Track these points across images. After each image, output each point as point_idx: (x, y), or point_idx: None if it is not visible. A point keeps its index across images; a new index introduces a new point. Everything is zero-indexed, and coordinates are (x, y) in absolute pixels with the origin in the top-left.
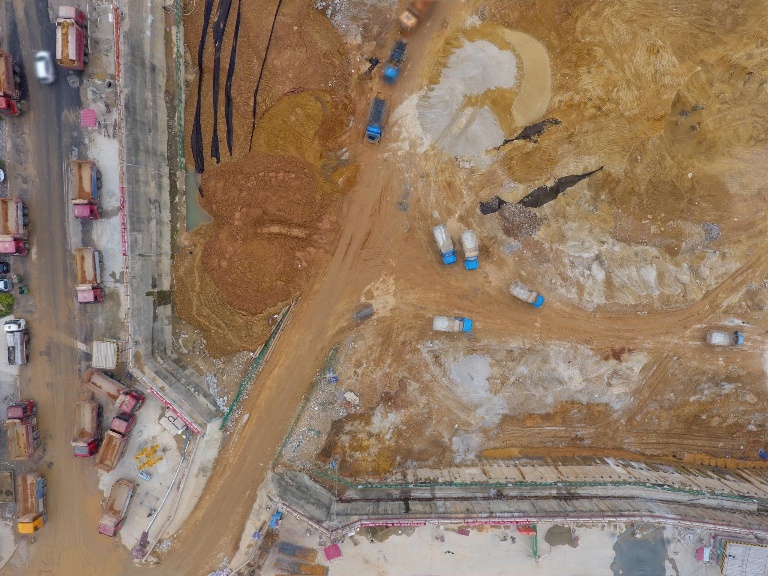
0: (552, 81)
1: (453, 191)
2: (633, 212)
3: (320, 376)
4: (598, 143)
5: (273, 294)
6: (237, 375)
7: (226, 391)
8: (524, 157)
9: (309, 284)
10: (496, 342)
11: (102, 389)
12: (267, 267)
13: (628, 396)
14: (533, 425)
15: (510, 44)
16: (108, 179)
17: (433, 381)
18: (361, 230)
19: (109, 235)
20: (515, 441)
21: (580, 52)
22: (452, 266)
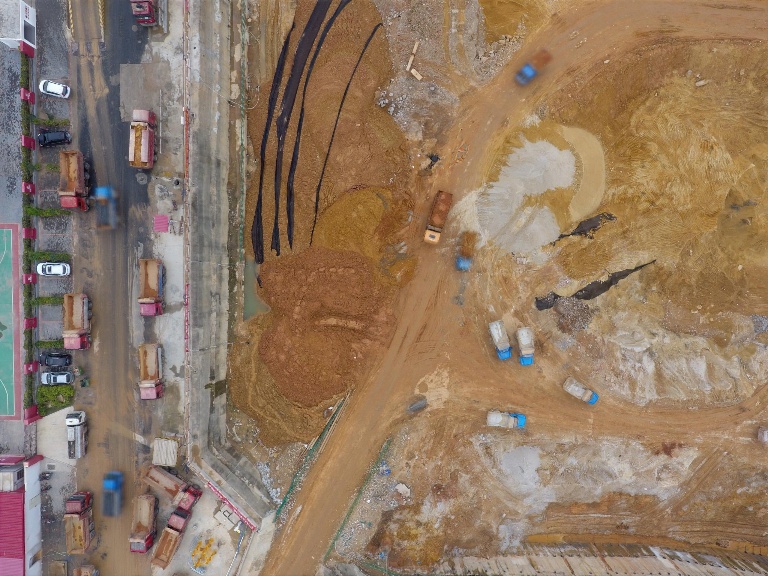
0: (606, 174)
1: (509, 286)
2: (683, 302)
3: (373, 469)
4: (652, 238)
5: (329, 387)
6: (291, 466)
7: (279, 482)
8: (580, 253)
9: (364, 376)
10: (548, 437)
11: (160, 484)
12: (324, 361)
13: (675, 487)
14: (578, 512)
15: (569, 143)
16: (172, 275)
17: (483, 472)
18: (417, 323)
19: (171, 329)
20: (560, 527)
21: (634, 146)
22: (506, 360)
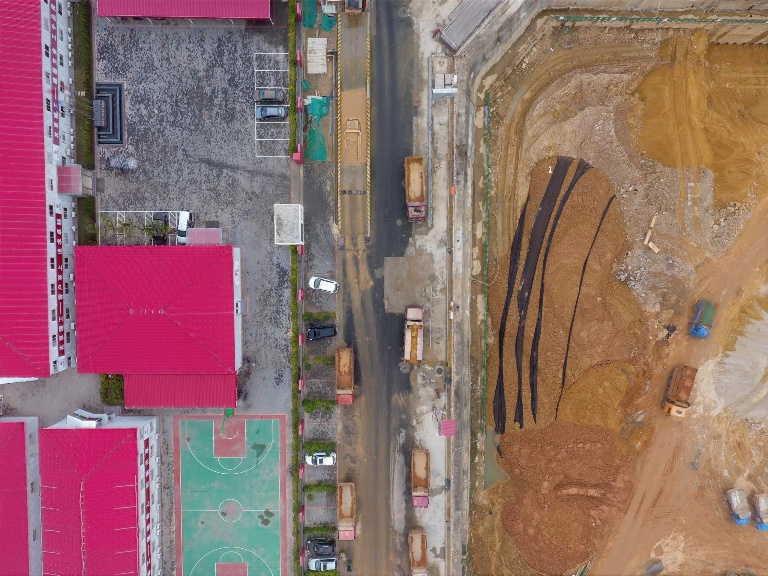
0: None
1: (743, 451)
2: None
3: None
4: None
5: (574, 557)
6: None
7: None
8: None
9: (603, 542)
10: None
11: None
12: (571, 533)
13: None
14: None
15: None
16: (434, 460)
17: None
18: (653, 489)
19: (432, 512)
20: None
21: None
22: None
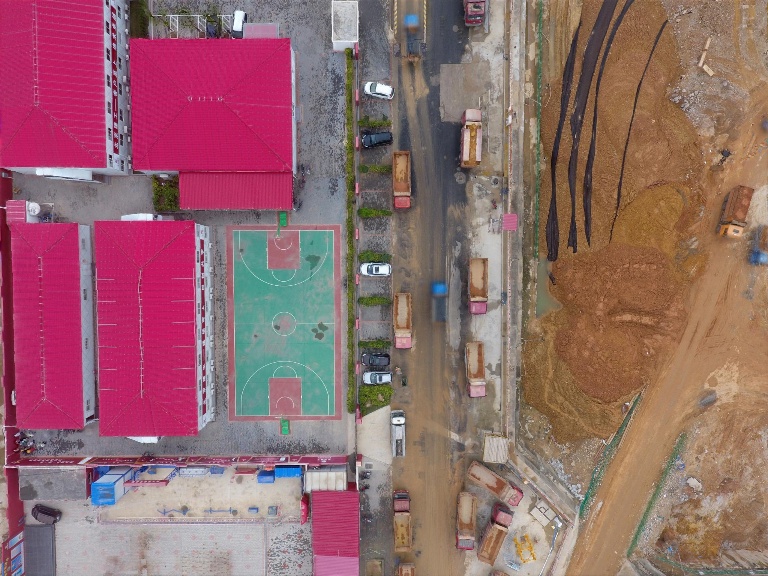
0: None
1: None
2: None
3: (669, 463)
4: None
5: (629, 383)
6: (589, 462)
7: (578, 478)
8: None
9: (656, 371)
10: None
11: (481, 481)
12: (627, 357)
13: None
14: None
15: None
16: (490, 273)
17: (763, 465)
18: (707, 318)
19: (487, 328)
20: None
21: None
22: None
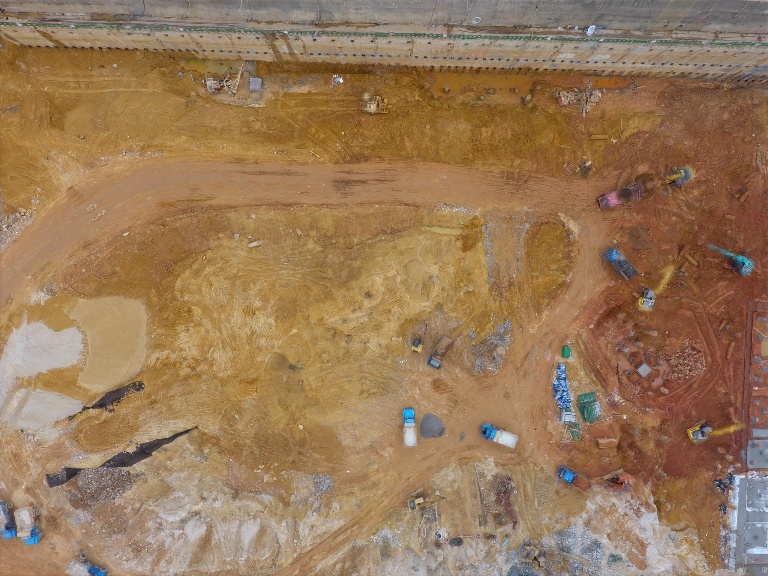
0: (148, 340)
1: (19, 463)
2: (245, 461)
3: None
4: (187, 406)
5: None
6: None
7: None
8: (98, 427)
9: None
10: None
11: None
12: None
13: None
14: None
15: (75, 321)
16: None
17: None
18: None
19: None
20: None
21: (178, 311)
22: None
